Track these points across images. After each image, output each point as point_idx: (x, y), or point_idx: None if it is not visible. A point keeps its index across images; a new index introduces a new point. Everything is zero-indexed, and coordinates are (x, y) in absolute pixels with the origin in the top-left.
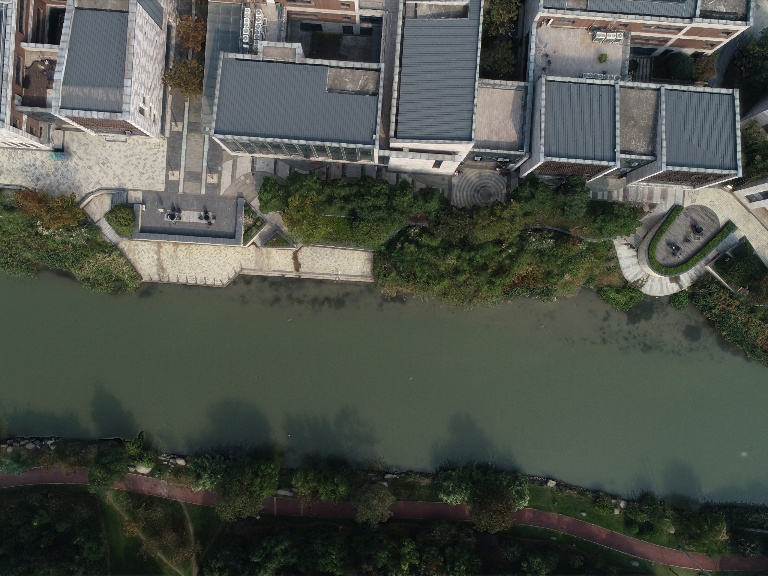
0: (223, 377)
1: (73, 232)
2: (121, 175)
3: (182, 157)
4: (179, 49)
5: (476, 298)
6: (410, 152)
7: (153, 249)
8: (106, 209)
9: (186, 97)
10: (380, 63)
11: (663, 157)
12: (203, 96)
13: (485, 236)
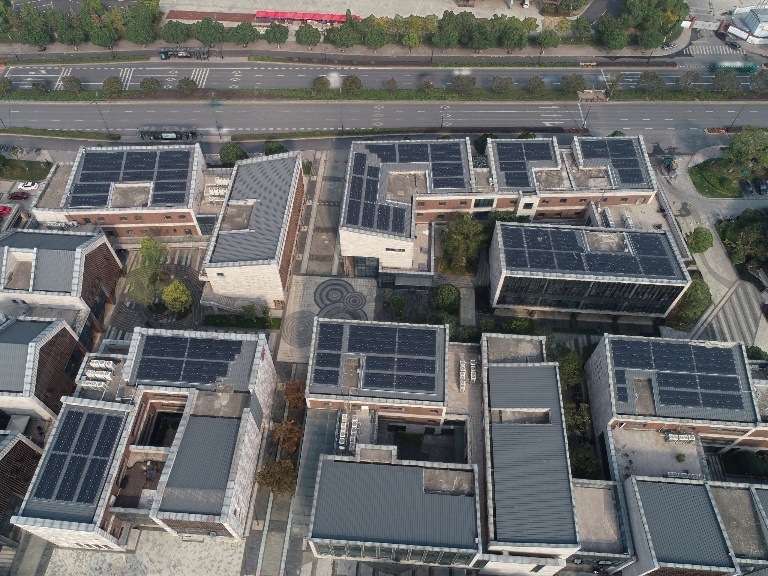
0: None
1: None
2: None
3: (259, 559)
4: (269, 448)
5: None
6: (510, 556)
7: None
8: None
9: (275, 495)
10: (473, 464)
11: None
12: (296, 495)
13: None
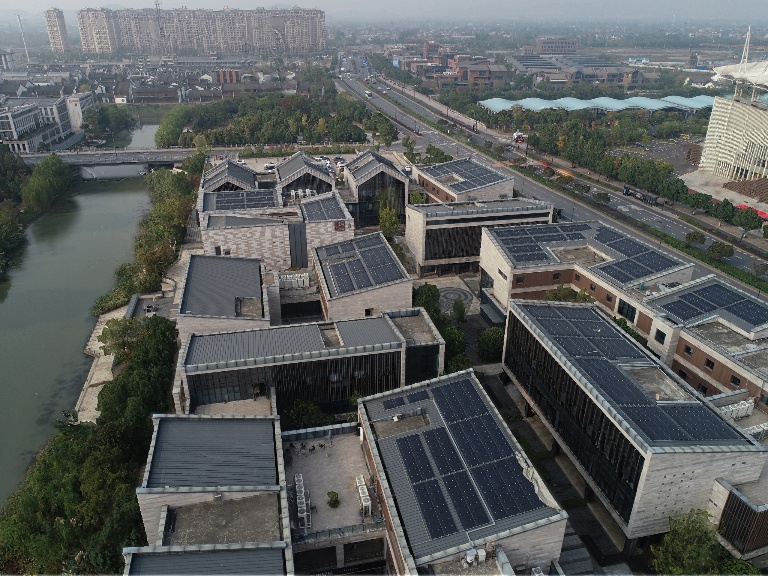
0: None
1: None
2: None
3: None
4: None
5: (4, 521)
6: None
7: None
8: None
9: None
10: None
11: (150, 547)
12: None
13: None
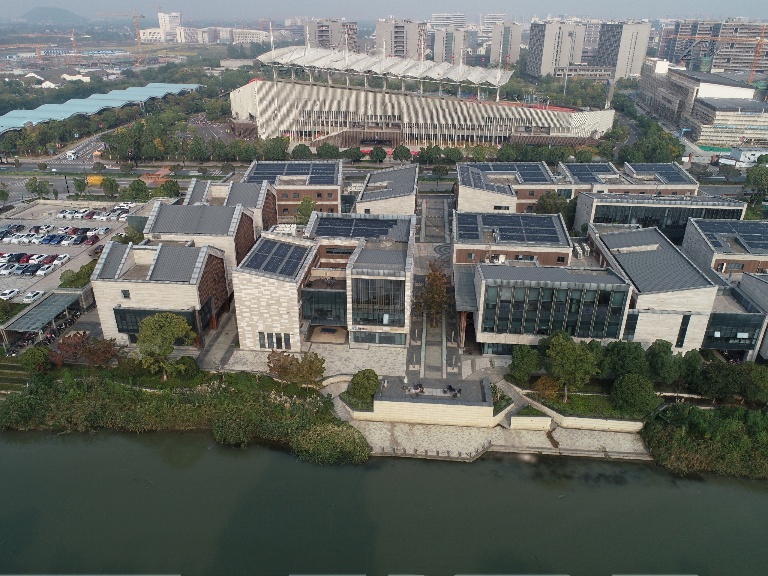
0: (484, 557)
1: (308, 398)
2: (362, 367)
3: (422, 358)
4: None
5: None
6: (657, 310)
7: (386, 428)
8: (341, 391)
9: (433, 310)
10: None
11: None
12: (456, 295)
13: (765, 388)
